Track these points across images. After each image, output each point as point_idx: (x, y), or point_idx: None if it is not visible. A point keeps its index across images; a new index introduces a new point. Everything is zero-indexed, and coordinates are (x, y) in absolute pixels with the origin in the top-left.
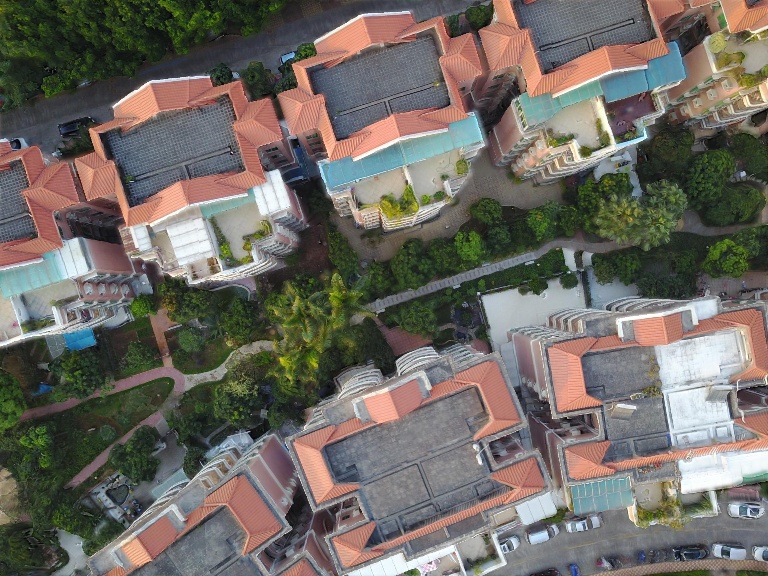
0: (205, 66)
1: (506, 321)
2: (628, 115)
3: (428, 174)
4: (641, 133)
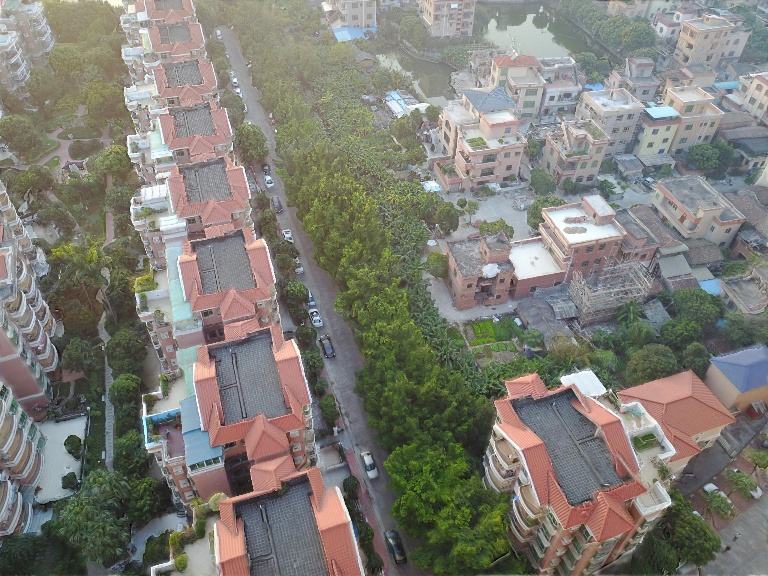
0: (310, 258)
1: (57, 436)
2: (175, 440)
3: (166, 308)
4: (150, 439)
